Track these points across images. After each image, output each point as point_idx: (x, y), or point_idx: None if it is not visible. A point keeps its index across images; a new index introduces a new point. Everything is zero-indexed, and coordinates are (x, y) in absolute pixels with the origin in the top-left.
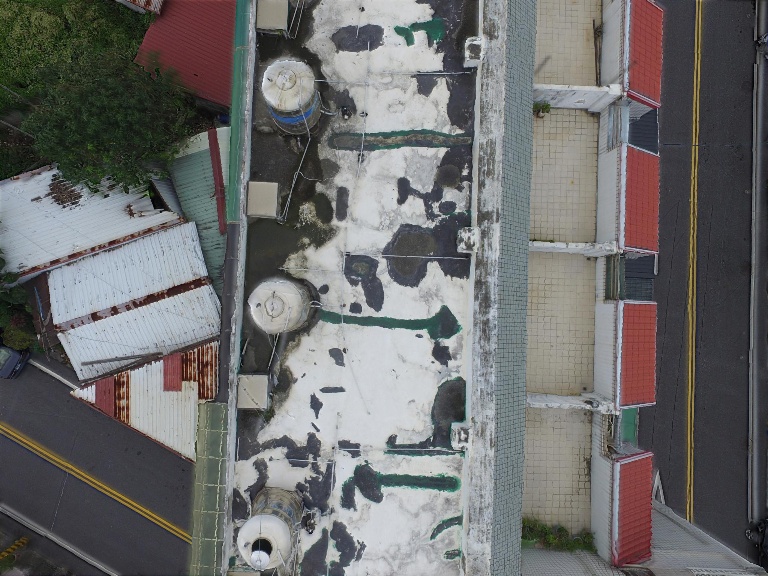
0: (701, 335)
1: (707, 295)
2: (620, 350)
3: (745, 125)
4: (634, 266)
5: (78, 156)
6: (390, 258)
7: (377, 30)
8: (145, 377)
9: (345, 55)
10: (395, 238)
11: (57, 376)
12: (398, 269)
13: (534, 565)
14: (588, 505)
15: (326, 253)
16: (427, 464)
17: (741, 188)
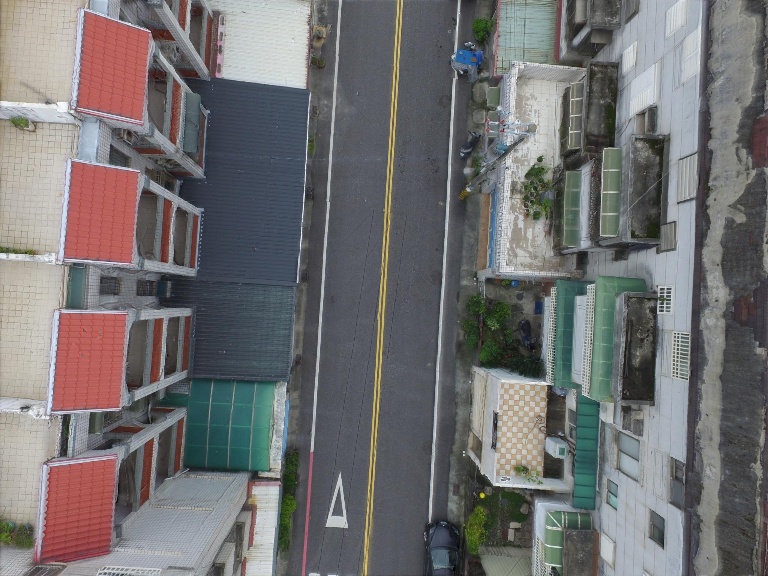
0: (389, 342)
1: (397, 303)
2: (54, 357)
3: (442, 138)
4: (276, 274)
5: None
6: None
7: None
8: None
9: None
10: None
11: None
12: None
13: None
14: None
15: None
16: None
17: (435, 199)
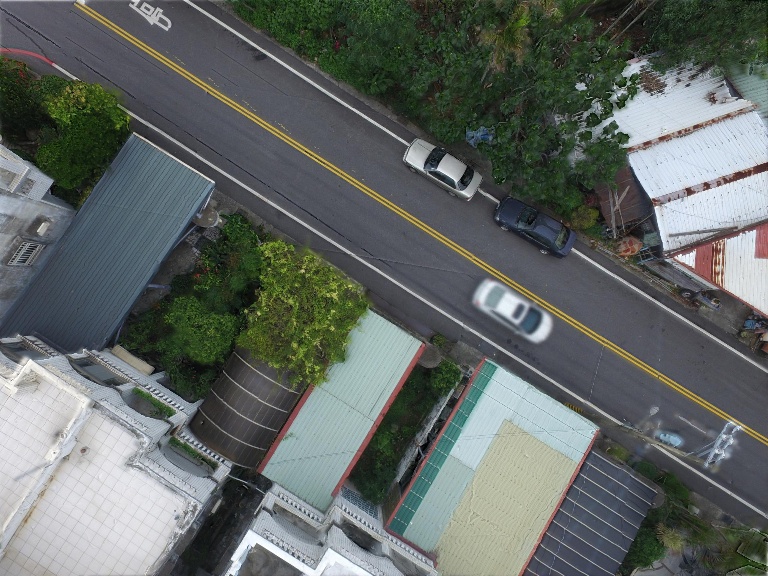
0: None
1: None
2: None
3: None
4: None
5: None
6: None
7: None
8: (739, 245)
9: None
10: None
11: (589, 259)
12: None
13: None
14: None
15: None
16: None
17: None
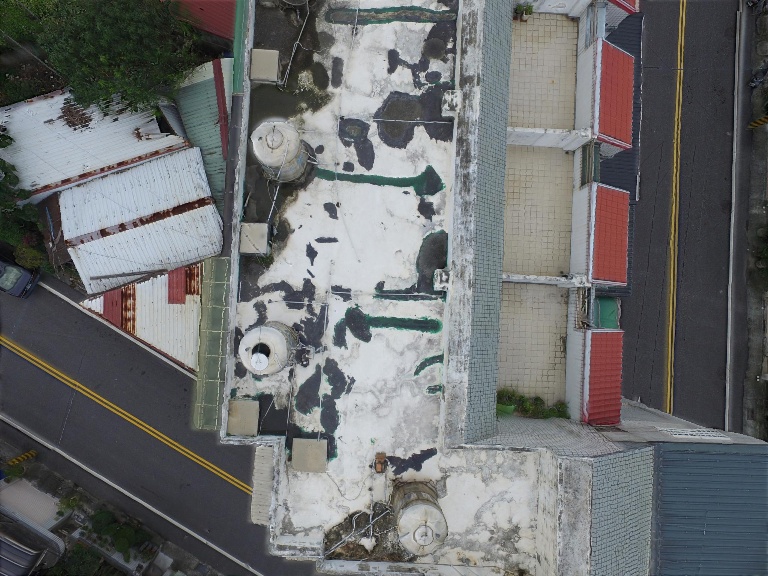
0: (682, 269)
1: (689, 231)
2: (593, 227)
3: (727, 70)
4: None
5: (90, 69)
6: (380, 122)
7: None
8: (151, 290)
9: None
10: (385, 104)
11: (66, 298)
12: (388, 132)
13: (510, 419)
14: (563, 379)
15: (322, 117)
16: (412, 308)
17: (723, 130)
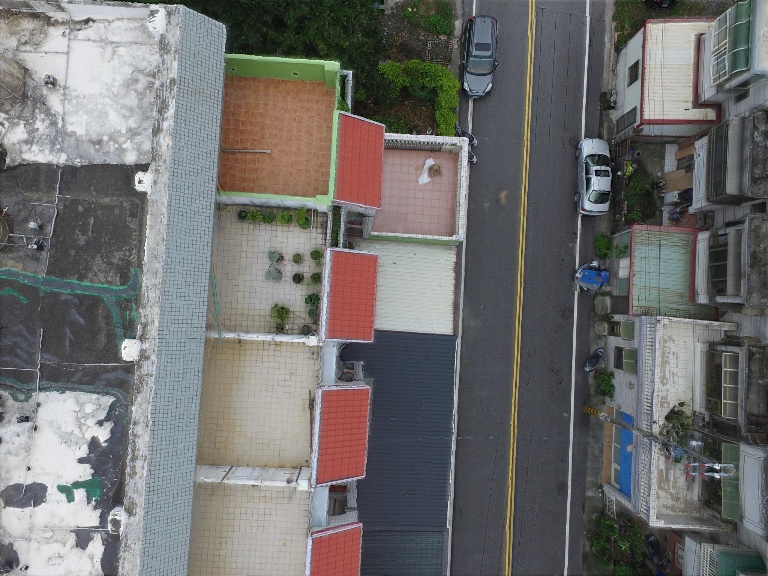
0: (518, 555)
1: (525, 515)
2: None
3: (565, 350)
4: (427, 520)
5: None
6: None
7: (41, 488)
8: None
9: (11, 511)
10: None
11: None
12: None
13: None
14: None
15: None
16: None
17: (560, 411)
